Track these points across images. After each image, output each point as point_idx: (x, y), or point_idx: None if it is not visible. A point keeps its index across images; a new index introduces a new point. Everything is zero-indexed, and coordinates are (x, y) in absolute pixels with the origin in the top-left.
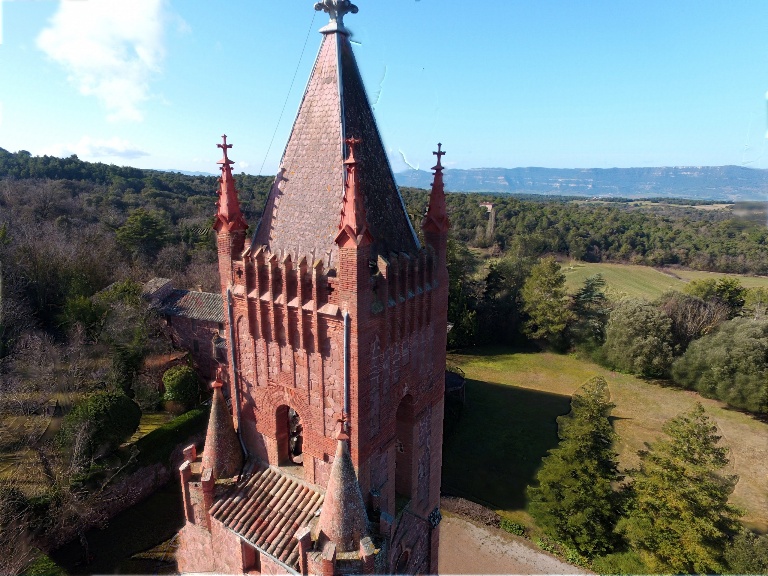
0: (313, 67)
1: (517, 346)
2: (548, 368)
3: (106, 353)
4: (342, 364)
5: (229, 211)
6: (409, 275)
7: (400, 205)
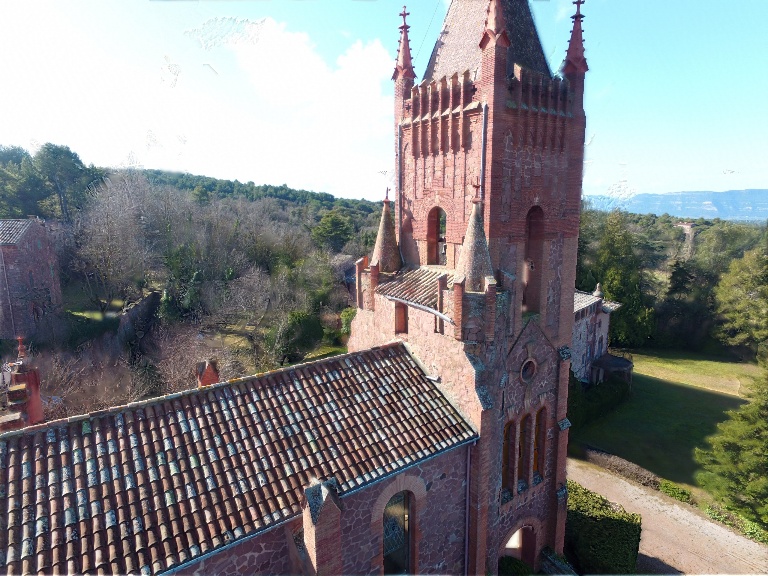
0: None
1: (707, 354)
2: None
3: (302, 288)
4: (480, 150)
5: (404, 62)
6: (543, 95)
7: (541, 50)
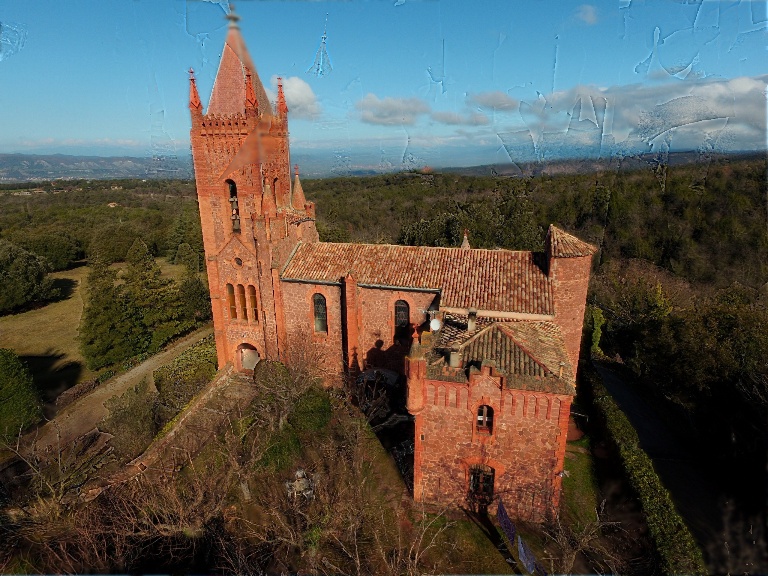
0: None
1: None
2: None
3: None
4: None
5: None
6: None
7: None
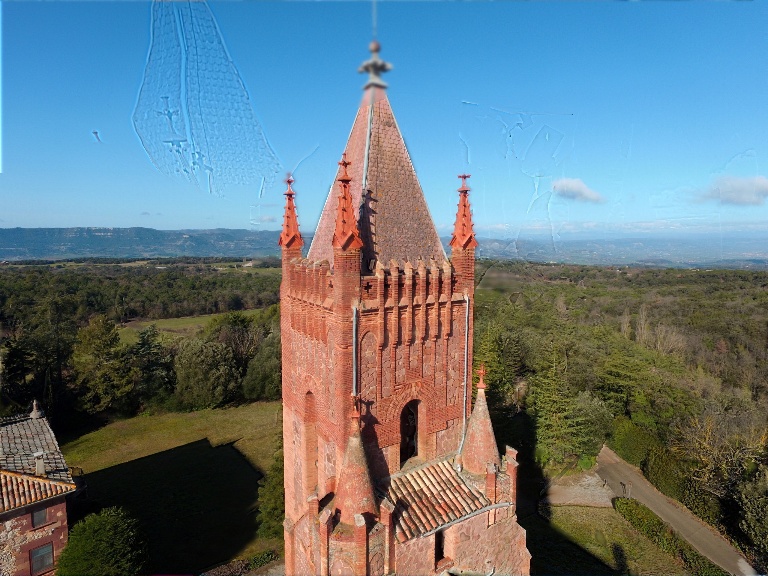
0: (371, 109)
1: (75, 429)
2: (132, 434)
3: None
4: (463, 337)
5: (356, 227)
6: None
7: None
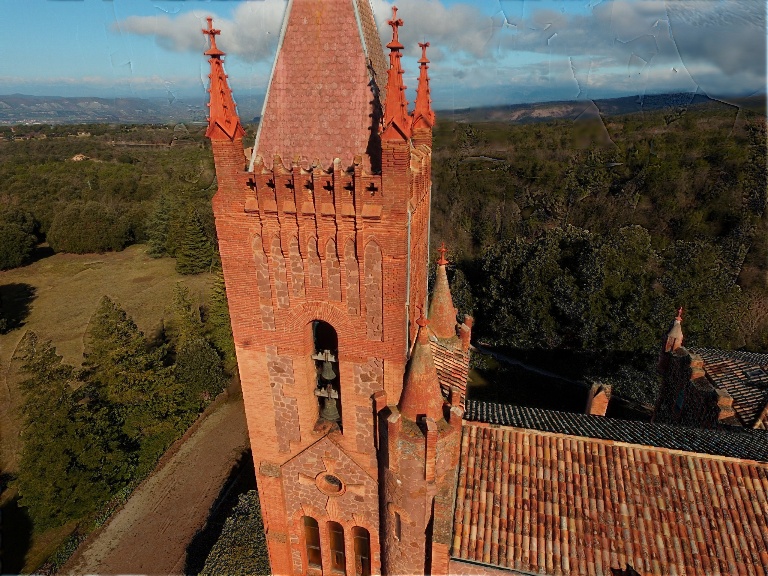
0: None
1: None
2: None
3: None
4: None
5: None
6: None
7: None
